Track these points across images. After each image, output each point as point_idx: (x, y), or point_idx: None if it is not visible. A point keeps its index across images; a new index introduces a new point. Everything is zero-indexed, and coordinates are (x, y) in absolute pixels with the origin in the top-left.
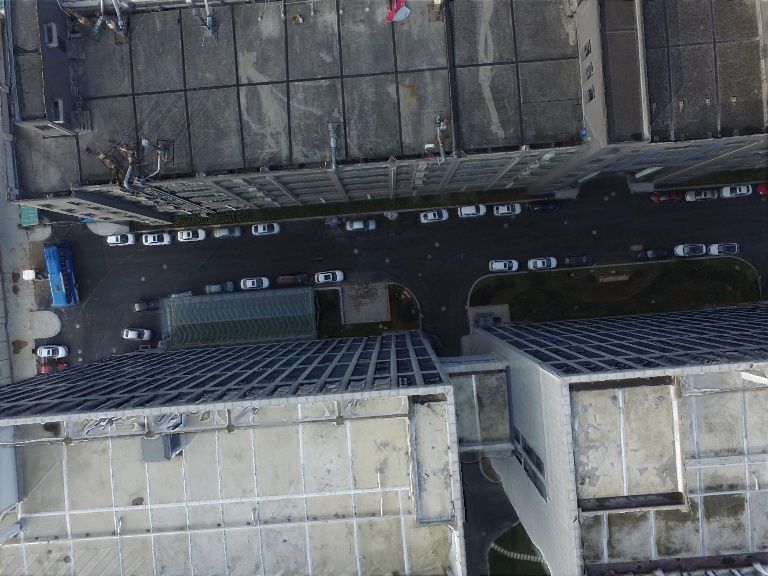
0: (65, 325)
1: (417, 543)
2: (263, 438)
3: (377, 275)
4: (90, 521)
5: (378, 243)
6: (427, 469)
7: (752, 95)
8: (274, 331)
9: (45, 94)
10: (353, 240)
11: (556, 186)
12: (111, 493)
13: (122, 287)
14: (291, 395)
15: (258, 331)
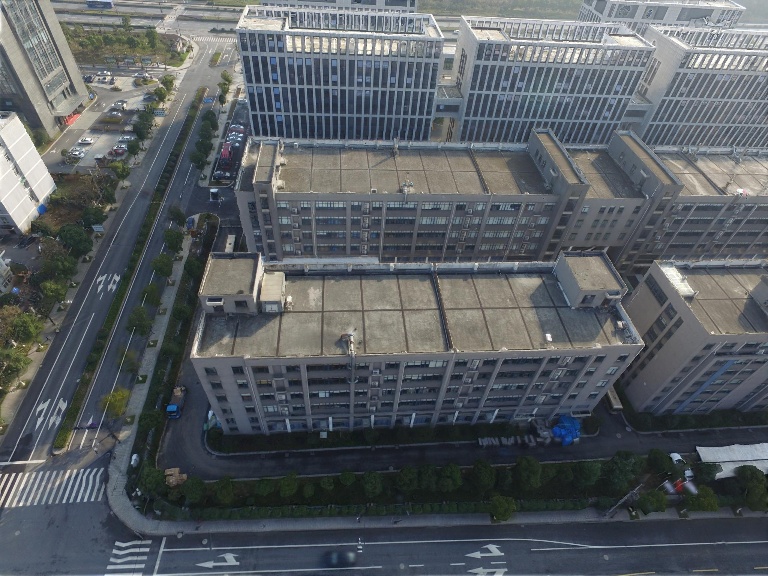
0: None
1: None
2: None
3: None
4: None
5: None
6: None
7: None
8: None
9: None
10: None
11: None
12: None
13: None
14: None
15: None
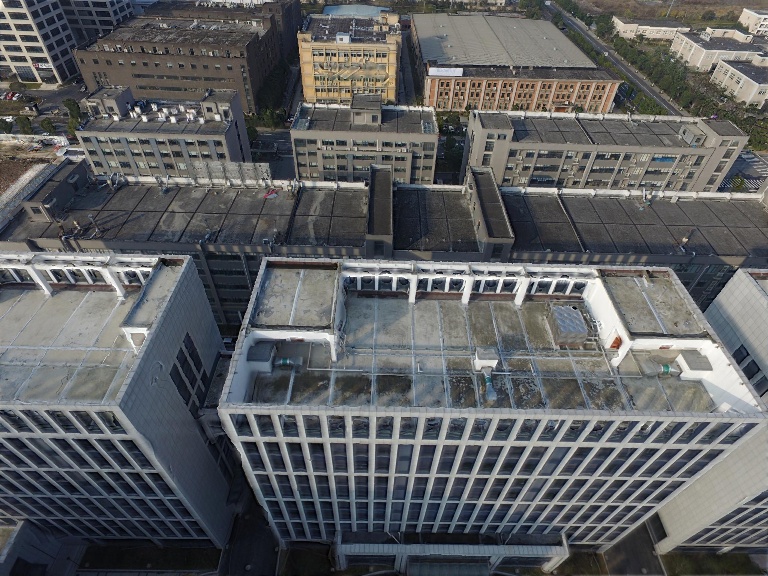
0: None
1: None
2: (46, 310)
3: None
4: None
5: None
6: (149, 297)
7: (471, 240)
8: None
9: (49, 193)
10: None
11: None
12: None
13: None
14: None
15: None
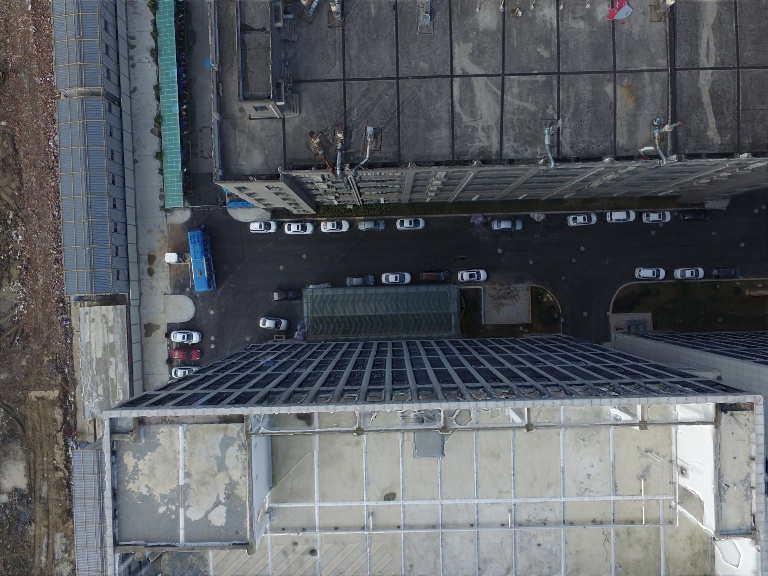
0: (199, 310)
1: (676, 554)
2: (523, 438)
3: (520, 276)
4: (339, 514)
5: (523, 244)
6: (728, 480)
7: None
8: (409, 328)
9: (272, 74)
10: (497, 240)
11: (717, 196)
12: (363, 487)
13: (259, 275)
14: (590, 396)
15: (393, 327)
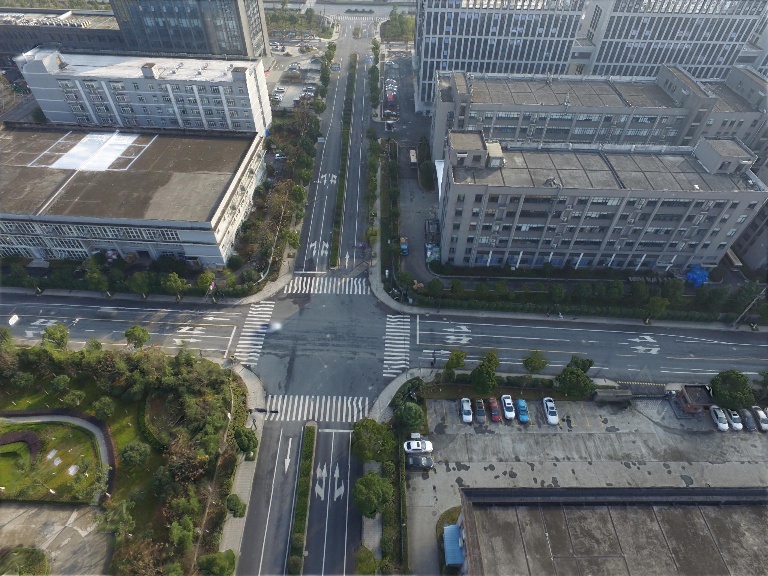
0: None
1: None
2: None
3: None
4: None
5: None
6: None
7: None
8: None
9: None
10: None
11: None
12: None
13: None
14: None
15: None
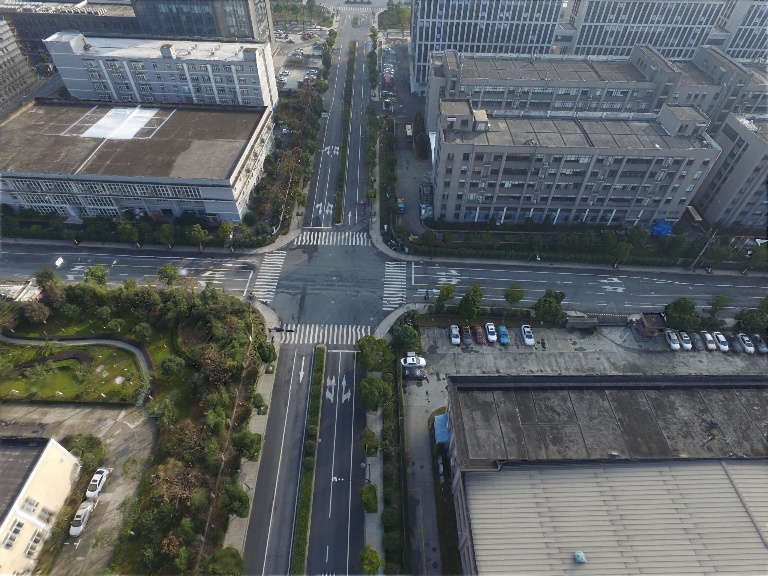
0: None
1: None
2: None
3: None
4: None
5: None
6: None
7: None
8: None
9: None
10: None
11: None
12: None
13: None
14: None
15: None
